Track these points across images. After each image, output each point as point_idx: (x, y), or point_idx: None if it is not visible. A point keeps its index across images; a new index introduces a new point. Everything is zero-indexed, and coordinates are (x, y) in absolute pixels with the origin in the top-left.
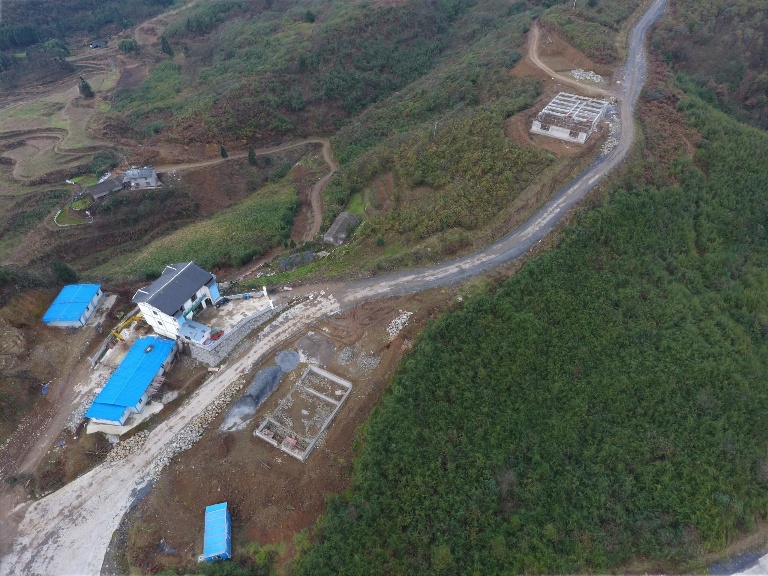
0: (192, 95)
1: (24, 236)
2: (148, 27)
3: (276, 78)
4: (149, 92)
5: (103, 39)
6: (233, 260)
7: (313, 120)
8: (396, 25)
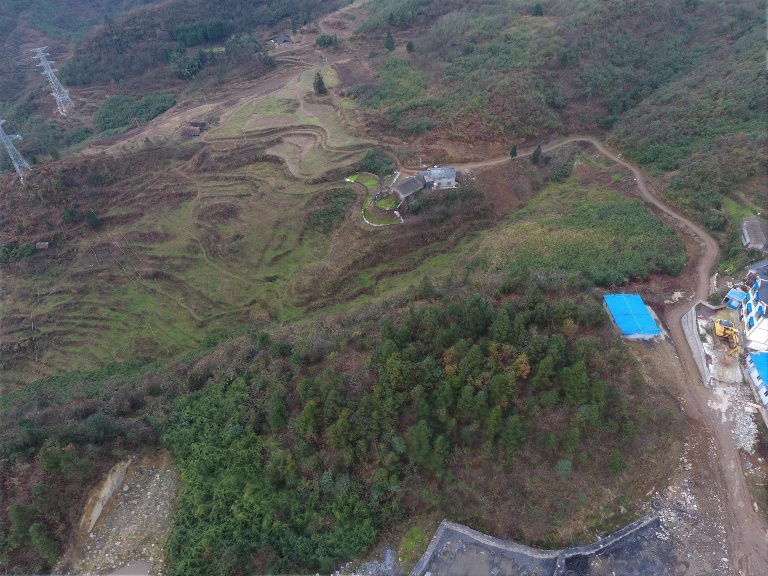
0: (449, 92)
1: (324, 235)
2: (334, 21)
3: (537, 74)
4: (395, 88)
5: (282, 33)
6: (671, 267)
7: (576, 117)
8: (643, 18)
